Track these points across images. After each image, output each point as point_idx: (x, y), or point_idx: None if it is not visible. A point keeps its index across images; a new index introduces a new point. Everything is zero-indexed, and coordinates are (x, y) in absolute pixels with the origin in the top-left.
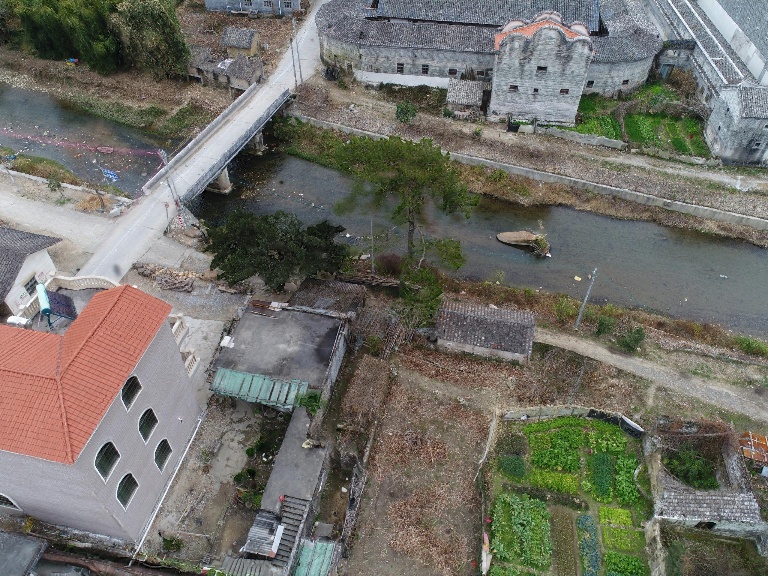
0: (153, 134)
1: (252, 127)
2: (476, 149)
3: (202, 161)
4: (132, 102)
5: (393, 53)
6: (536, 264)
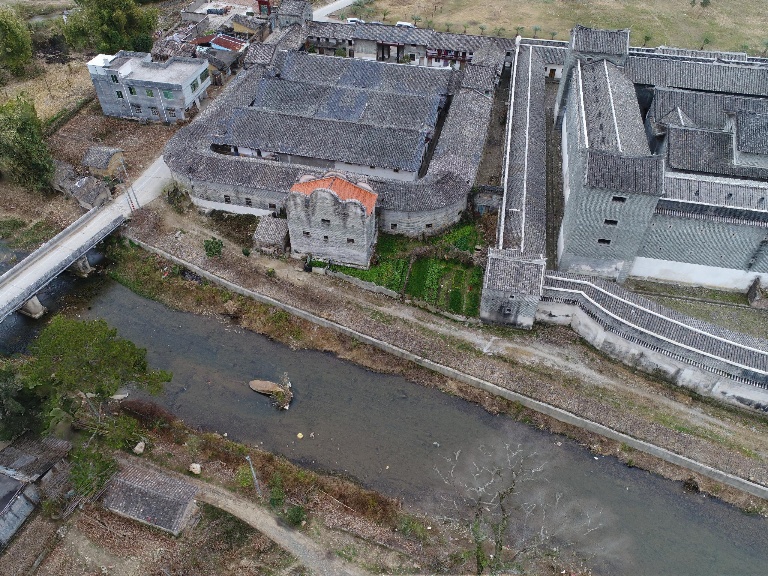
0: (5, 247)
1: (69, 257)
2: (268, 288)
3: (11, 291)
4: (1, 211)
5: (218, 187)
6: (272, 416)
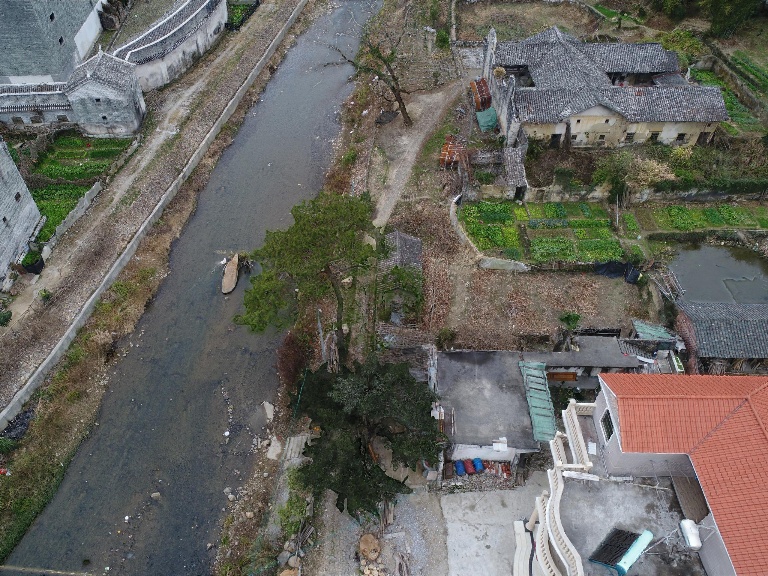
0: None
1: None
2: (69, 305)
3: None
4: None
5: None
6: None
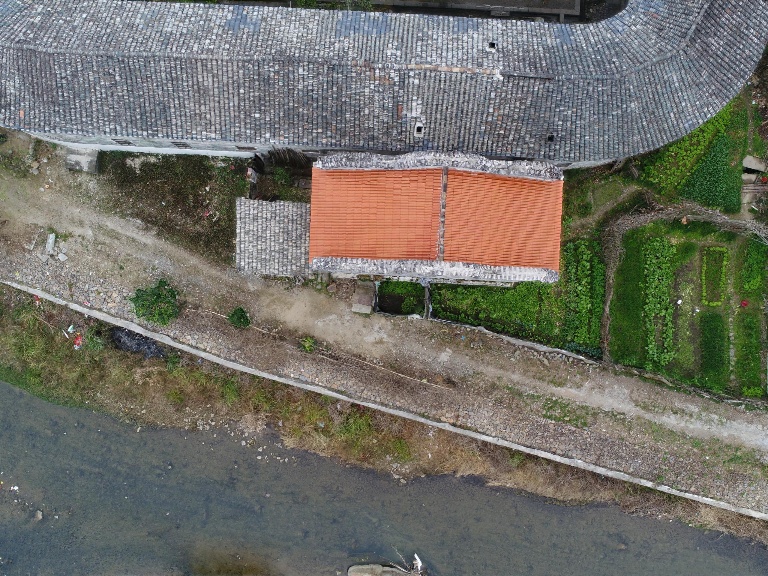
0: None
1: None
2: (311, 368)
3: None
4: None
5: None
6: None
